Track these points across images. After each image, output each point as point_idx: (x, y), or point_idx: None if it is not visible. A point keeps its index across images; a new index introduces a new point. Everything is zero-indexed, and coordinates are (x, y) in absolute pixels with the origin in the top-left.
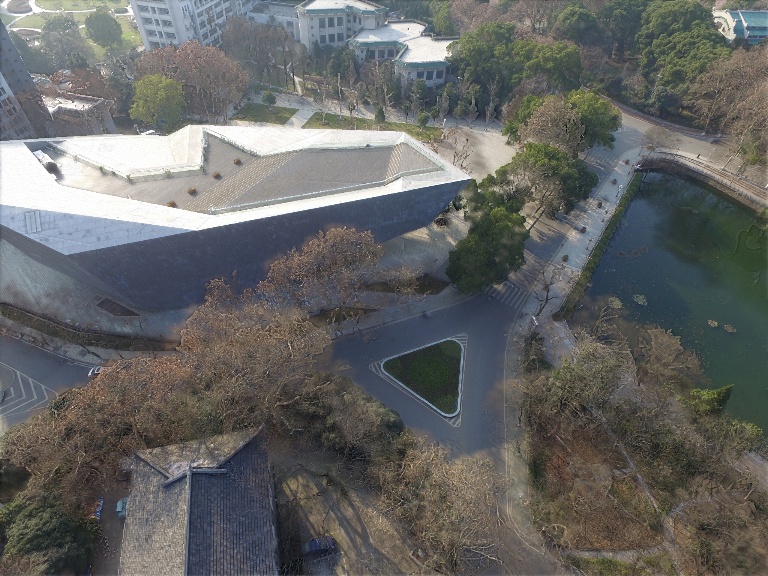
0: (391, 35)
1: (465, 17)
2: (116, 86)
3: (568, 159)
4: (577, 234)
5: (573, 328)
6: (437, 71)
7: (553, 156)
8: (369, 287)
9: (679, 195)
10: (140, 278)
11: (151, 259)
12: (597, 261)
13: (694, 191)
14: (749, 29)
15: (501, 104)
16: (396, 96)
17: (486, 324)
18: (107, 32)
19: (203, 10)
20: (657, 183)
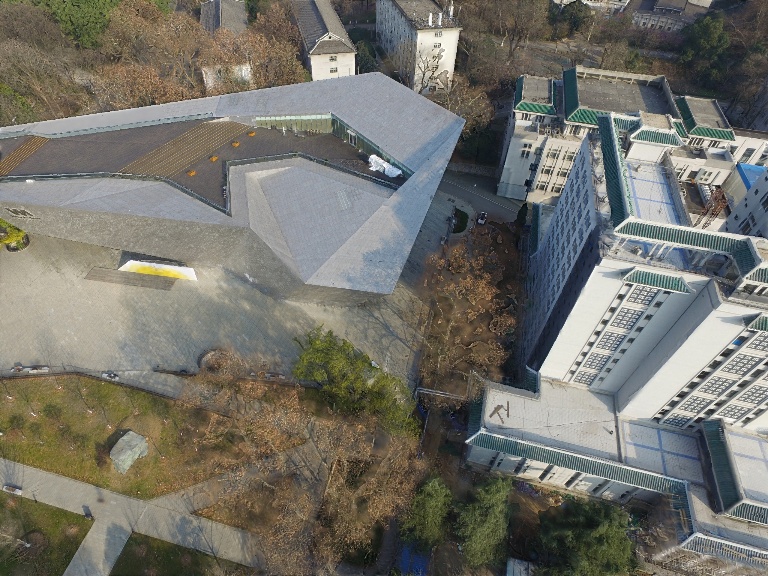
0: None
1: None
2: None
3: None
4: None
5: None
6: None
7: None
8: None
9: None
10: None
11: None
12: None
13: None
14: None
15: None
16: None
17: None
18: None
19: None
20: None
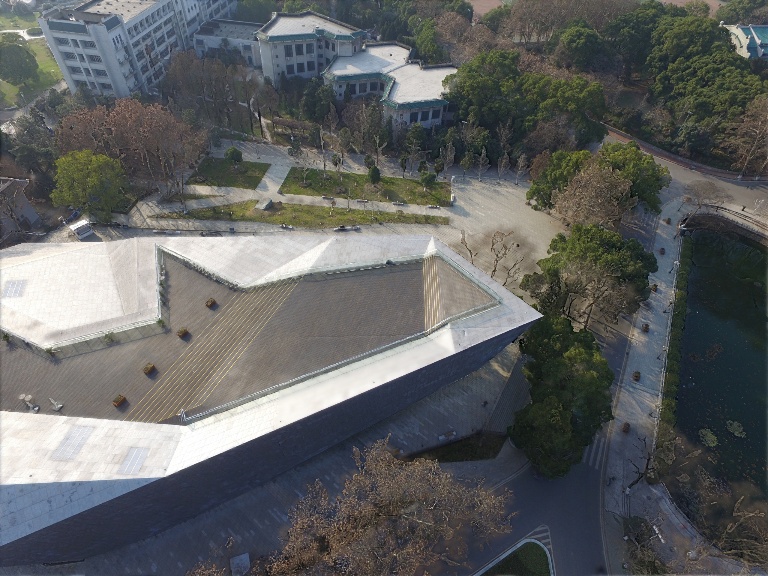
0: (372, 64)
1: (454, 38)
2: (30, 157)
3: (624, 242)
4: (640, 335)
5: (669, 486)
6: (433, 110)
7: (608, 241)
8: (406, 460)
9: (725, 254)
10: (78, 541)
11: (93, 522)
12: (677, 380)
13: (739, 248)
14: (762, 46)
15: (513, 151)
16: (387, 143)
17: (568, 504)
18: (18, 67)
19: (140, 38)
20: (701, 243)
